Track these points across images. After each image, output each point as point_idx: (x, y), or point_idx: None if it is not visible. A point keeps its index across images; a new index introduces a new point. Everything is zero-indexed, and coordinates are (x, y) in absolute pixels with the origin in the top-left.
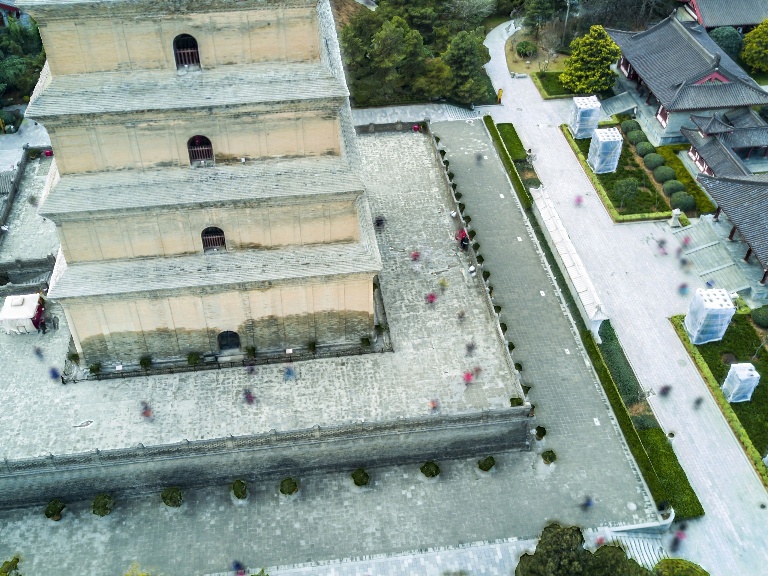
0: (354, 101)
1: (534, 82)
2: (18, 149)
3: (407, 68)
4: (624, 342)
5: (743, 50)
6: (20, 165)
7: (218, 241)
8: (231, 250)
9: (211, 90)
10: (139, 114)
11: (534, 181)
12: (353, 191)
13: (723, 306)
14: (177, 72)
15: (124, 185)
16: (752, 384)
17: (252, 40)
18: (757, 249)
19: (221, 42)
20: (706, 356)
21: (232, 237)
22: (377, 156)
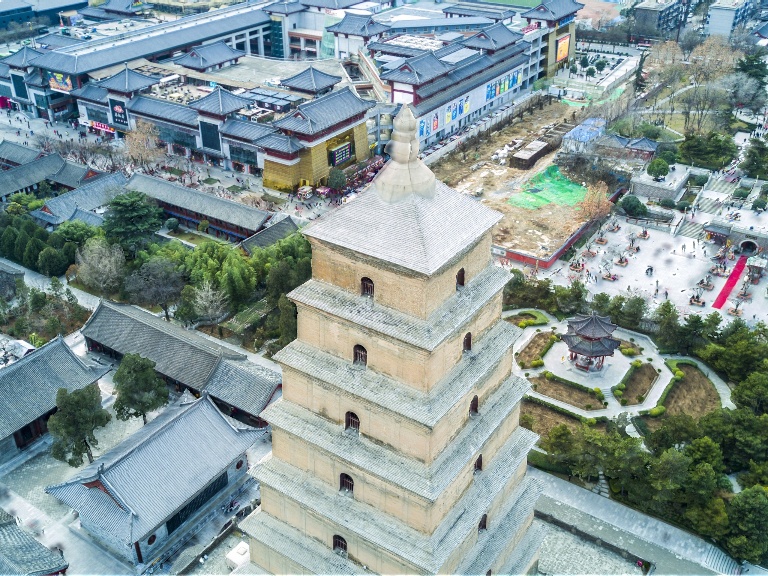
0: (626, 496)
1: None
2: None
3: (690, 492)
4: None
5: None
6: None
7: None
8: None
9: (351, 516)
10: None
11: None
12: None
13: None
14: (339, 492)
15: (290, 538)
16: None
17: (387, 499)
18: None
19: (368, 490)
20: None
21: None
22: (583, 572)
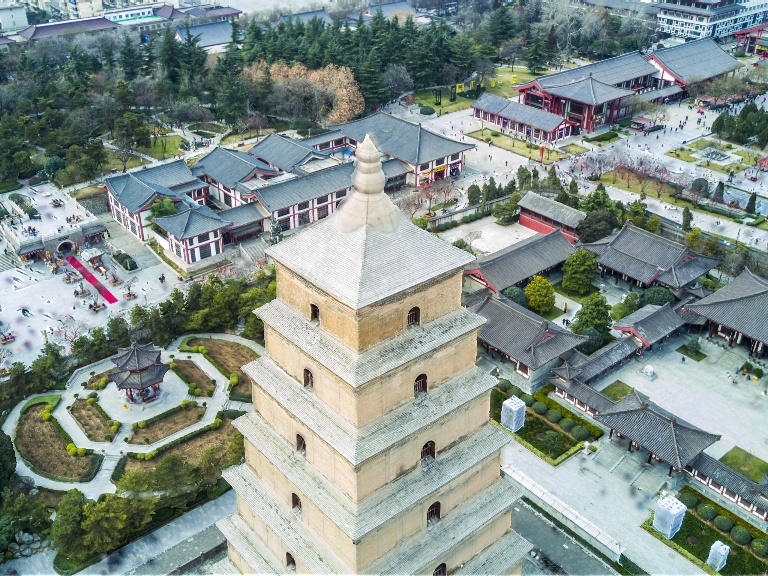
0: None
1: None
2: None
3: None
4: (632, 558)
5: (529, 300)
6: None
7: None
8: None
9: (453, 531)
10: None
11: None
12: None
13: (680, 508)
14: (428, 529)
15: None
16: (727, 554)
17: (468, 486)
18: (665, 458)
19: (453, 496)
20: (682, 545)
21: None
22: None
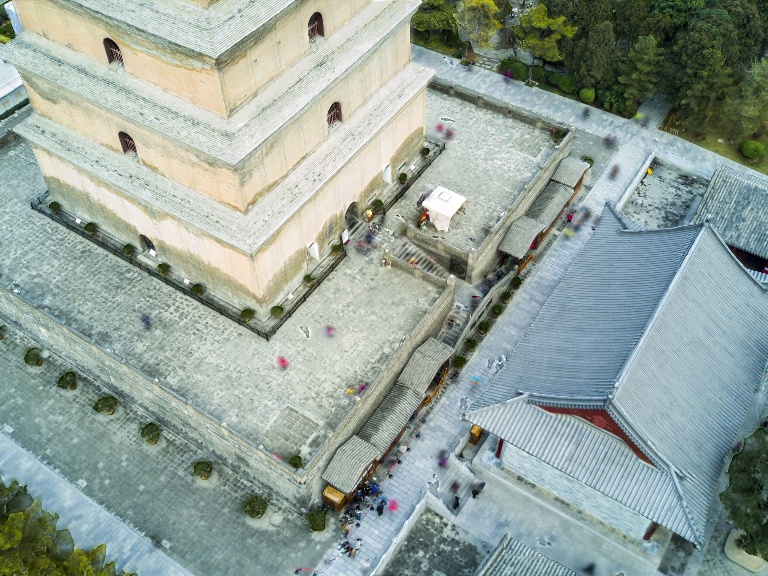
0: None
1: None
2: None
3: None
4: None
5: None
6: None
7: None
8: None
9: None
10: None
11: None
12: None
13: None
14: None
15: None
16: None
17: None
18: None
19: None
20: None
21: None
22: None
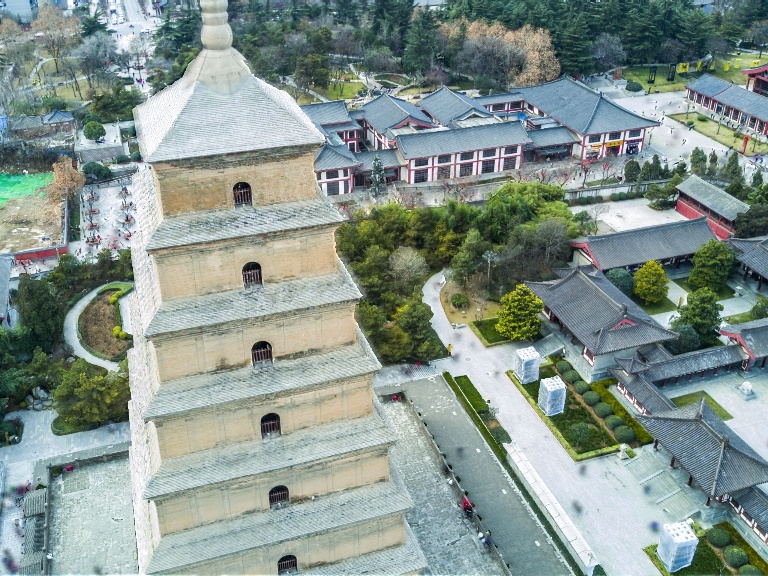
0: None
1: (473, 331)
2: (27, 460)
3: (370, 337)
4: None
5: (635, 286)
6: (48, 486)
7: (289, 564)
8: (301, 571)
9: (292, 452)
10: (234, 480)
11: (500, 430)
12: (404, 509)
13: (688, 539)
14: (263, 441)
15: (217, 536)
16: None
17: (322, 409)
18: (700, 480)
19: (298, 414)
20: None
21: (303, 560)
22: None
